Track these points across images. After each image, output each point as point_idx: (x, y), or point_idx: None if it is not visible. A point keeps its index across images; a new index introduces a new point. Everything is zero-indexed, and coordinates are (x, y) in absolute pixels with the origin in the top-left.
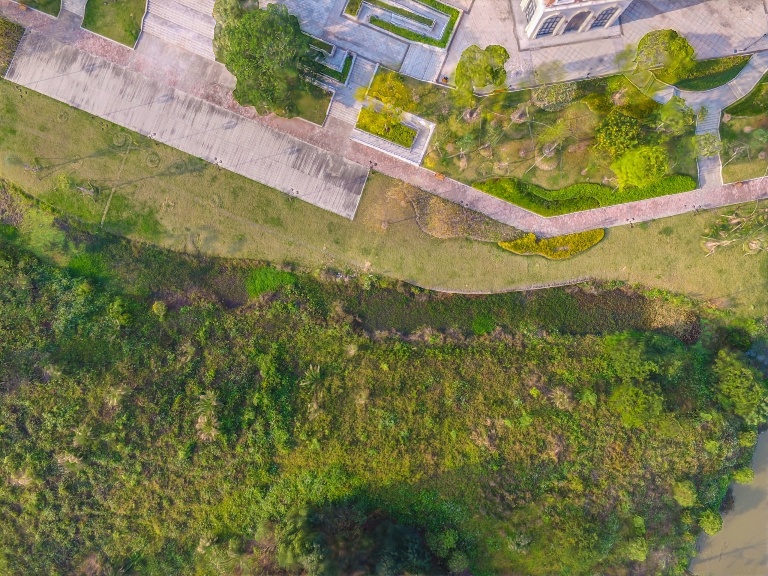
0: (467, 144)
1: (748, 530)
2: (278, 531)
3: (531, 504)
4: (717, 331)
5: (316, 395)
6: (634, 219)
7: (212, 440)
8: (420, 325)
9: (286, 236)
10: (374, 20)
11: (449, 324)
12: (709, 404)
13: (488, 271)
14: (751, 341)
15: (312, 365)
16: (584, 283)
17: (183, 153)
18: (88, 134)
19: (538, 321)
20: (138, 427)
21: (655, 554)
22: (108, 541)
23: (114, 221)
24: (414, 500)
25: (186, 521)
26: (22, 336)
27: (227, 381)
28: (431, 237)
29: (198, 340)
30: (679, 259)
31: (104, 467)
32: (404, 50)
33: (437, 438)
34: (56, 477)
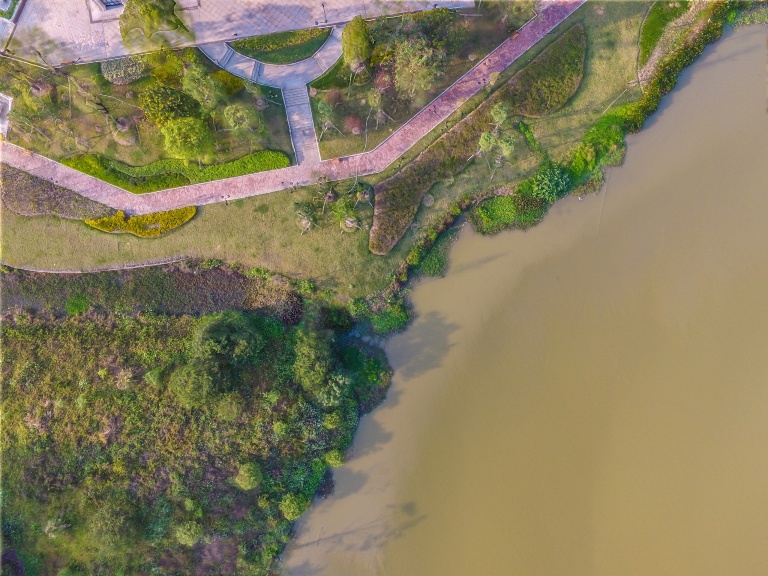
0: (45, 119)
1: (348, 515)
2: None
3: (69, 487)
4: (319, 311)
5: None
6: (229, 196)
7: None
8: (11, 305)
9: None
10: None
11: (42, 304)
12: (287, 385)
13: (76, 250)
14: (354, 321)
15: None
16: (181, 262)
17: None
18: None
19: (134, 301)
20: None
21: (230, 539)
22: None
23: None
24: None
25: None
26: None
27: None
28: (17, 215)
29: None
30: (274, 237)
31: None
32: None
33: None
34: None
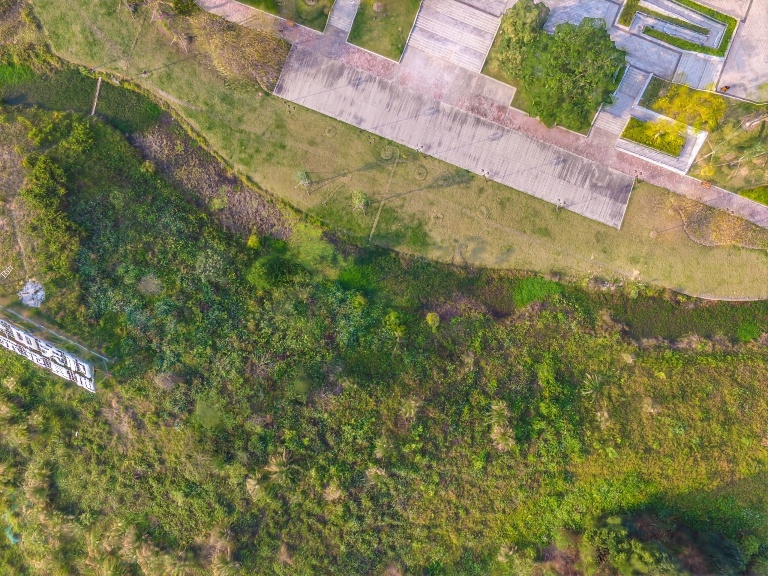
0: None
1: None
2: (590, 540)
3: None
4: None
5: (598, 404)
6: None
7: (508, 450)
8: (686, 332)
9: (554, 246)
10: (648, 30)
11: (714, 331)
12: None
13: (756, 278)
14: None
15: (589, 374)
16: None
17: (450, 165)
18: (356, 148)
19: None
20: (432, 438)
21: None
22: (407, 551)
23: (383, 234)
24: (712, 507)
25: (482, 530)
26: (310, 349)
27: (509, 391)
28: (699, 245)
29: (473, 351)
30: None
31: (403, 478)
32: (676, 59)
33: (728, 445)
34: (358, 488)
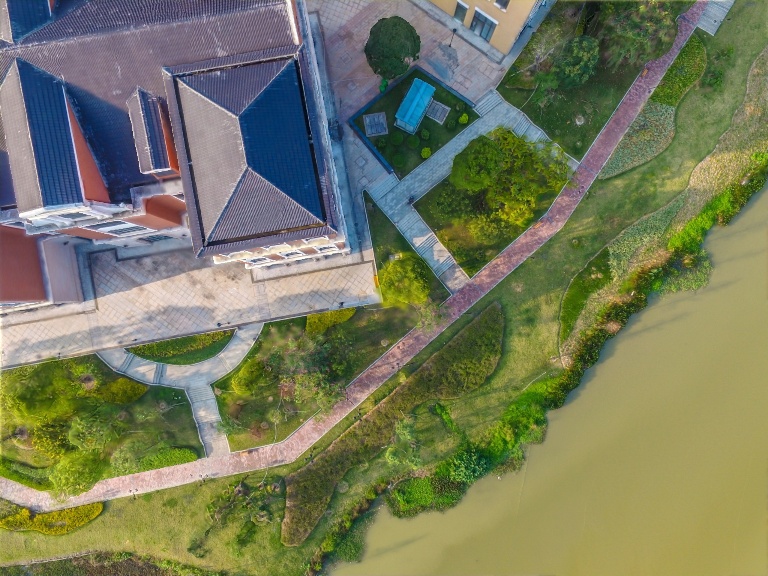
0: None
1: None
2: None
3: None
4: None
5: None
6: (137, 490)
7: None
8: None
9: None
10: None
11: None
12: None
13: None
14: None
15: None
16: (90, 555)
17: None
18: None
19: None
20: None
21: None
22: None
23: None
24: None
25: None
26: None
27: None
28: None
29: None
30: (183, 532)
31: None
32: None
33: None
34: None
